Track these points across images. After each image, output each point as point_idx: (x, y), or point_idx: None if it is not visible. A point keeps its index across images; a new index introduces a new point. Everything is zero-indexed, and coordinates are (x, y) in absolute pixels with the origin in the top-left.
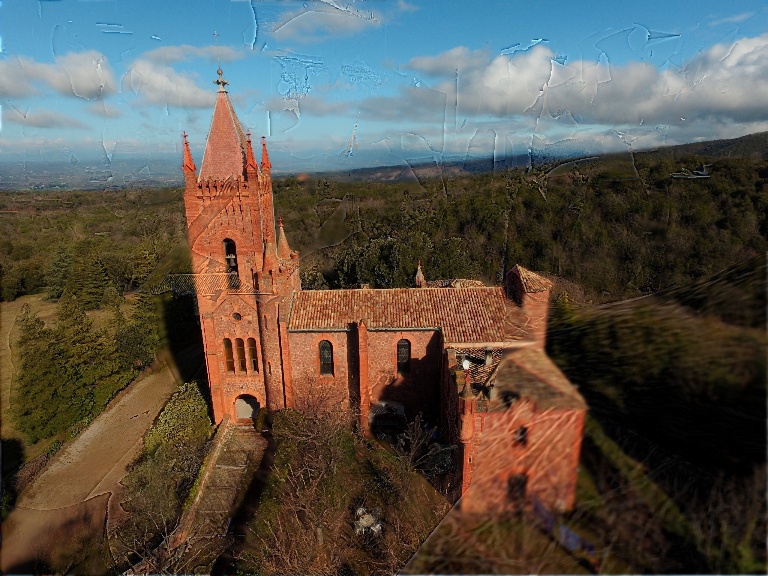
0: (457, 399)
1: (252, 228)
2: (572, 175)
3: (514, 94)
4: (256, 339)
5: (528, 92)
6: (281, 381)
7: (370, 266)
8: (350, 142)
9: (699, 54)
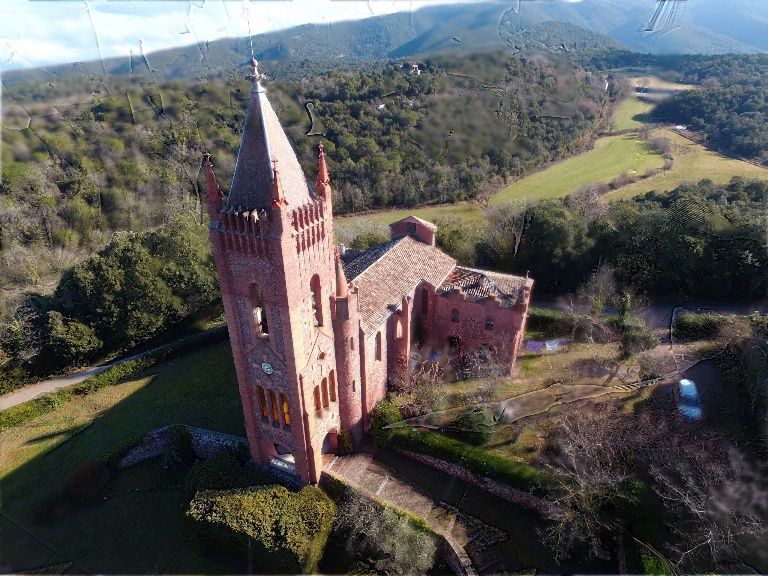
0: (491, 312)
1: (329, 253)
2: (216, 122)
3: (150, 35)
4: (334, 369)
5: (169, 34)
6: (360, 392)
7: (155, 271)
8: (449, 147)
9: (325, 21)
